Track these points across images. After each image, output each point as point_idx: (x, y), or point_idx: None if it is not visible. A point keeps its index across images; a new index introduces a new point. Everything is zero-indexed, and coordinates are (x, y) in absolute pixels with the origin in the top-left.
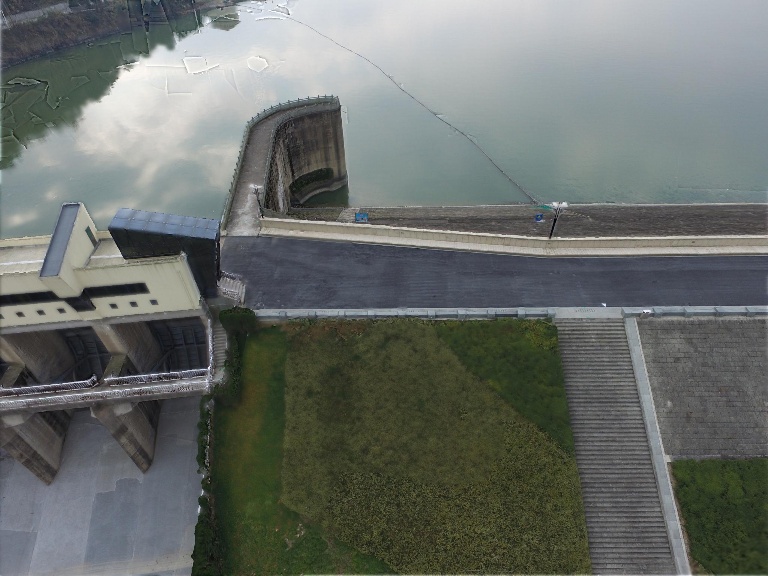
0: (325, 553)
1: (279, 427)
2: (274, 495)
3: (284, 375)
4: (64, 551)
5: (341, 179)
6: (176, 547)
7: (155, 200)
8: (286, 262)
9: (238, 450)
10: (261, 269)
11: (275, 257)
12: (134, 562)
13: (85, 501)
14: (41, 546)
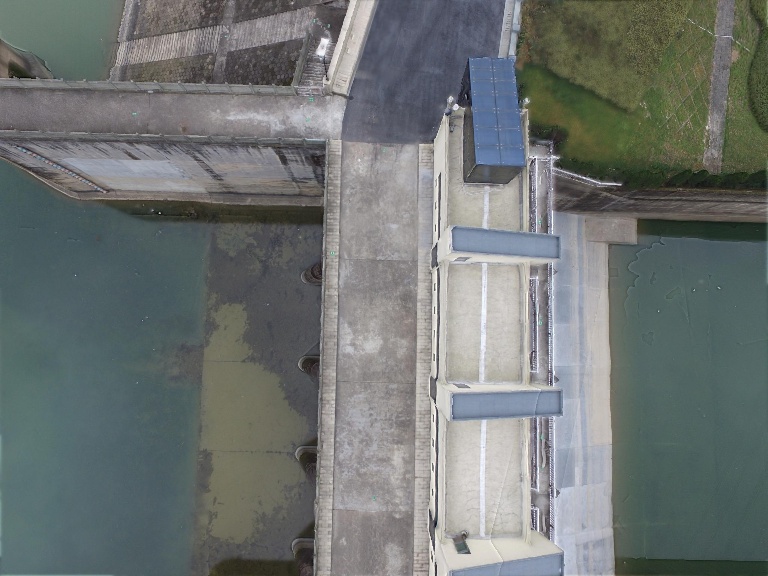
0: (656, 91)
1: (589, 100)
2: (623, 120)
3: (558, 80)
4: (561, 341)
5: (26, 61)
6: (566, 252)
7: (7, 388)
8: (413, 60)
9: (584, 149)
10: (422, 90)
11: (400, 73)
12: (572, 284)
13: (531, 331)
14: (557, 361)
